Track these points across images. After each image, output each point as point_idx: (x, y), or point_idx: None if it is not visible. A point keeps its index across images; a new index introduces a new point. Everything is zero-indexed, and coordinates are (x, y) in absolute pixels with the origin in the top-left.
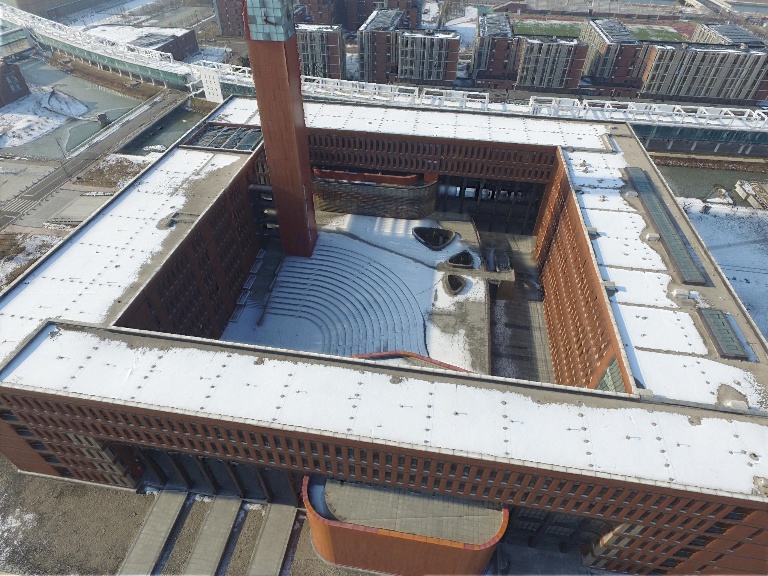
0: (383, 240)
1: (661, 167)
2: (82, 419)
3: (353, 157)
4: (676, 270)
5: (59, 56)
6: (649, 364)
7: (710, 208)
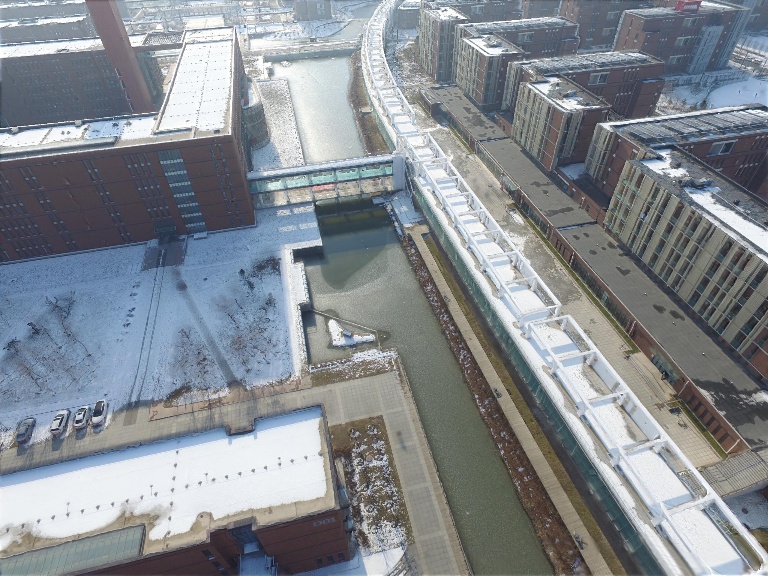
0: None
1: (412, 281)
2: None
3: None
4: None
5: None
6: None
7: (271, 300)
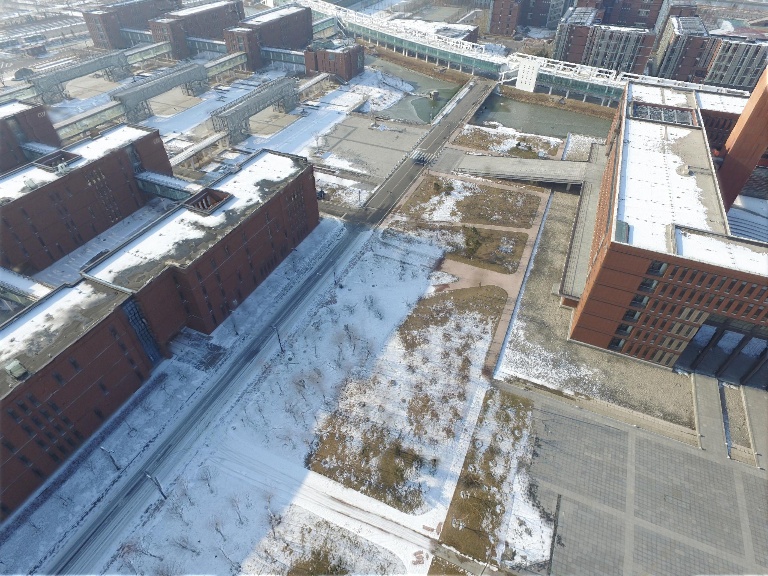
0: None
1: None
2: (728, 295)
3: None
4: None
5: (362, 42)
6: None
7: None
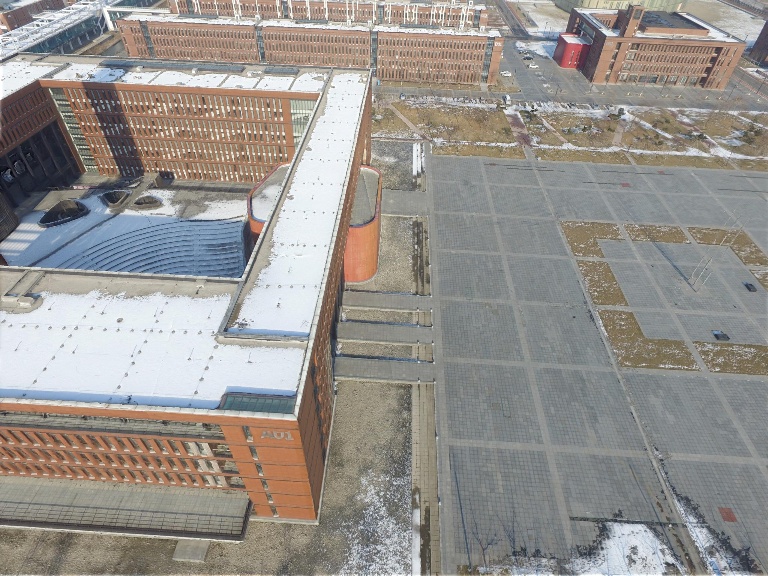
0: (45, 247)
1: None
2: None
3: None
4: (230, 71)
5: None
6: (300, 89)
7: None
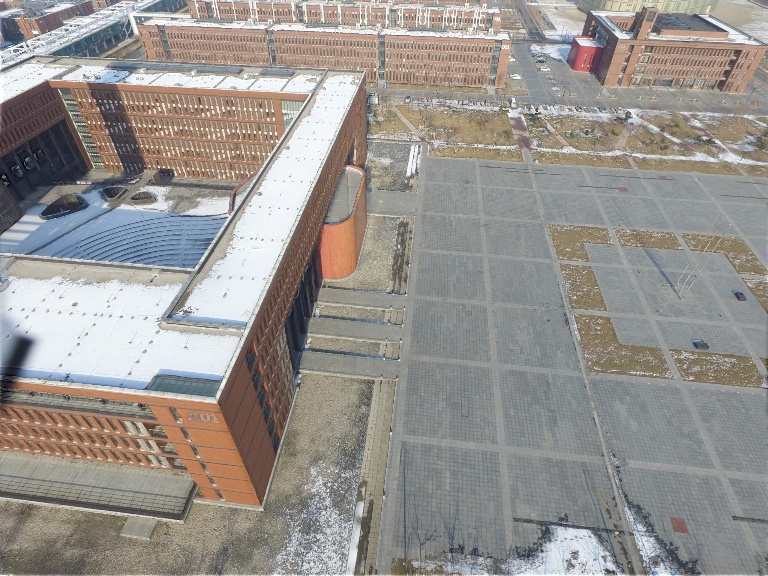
0: (43, 238)
1: None
2: None
3: None
4: (227, 73)
5: None
6: (291, 90)
7: None
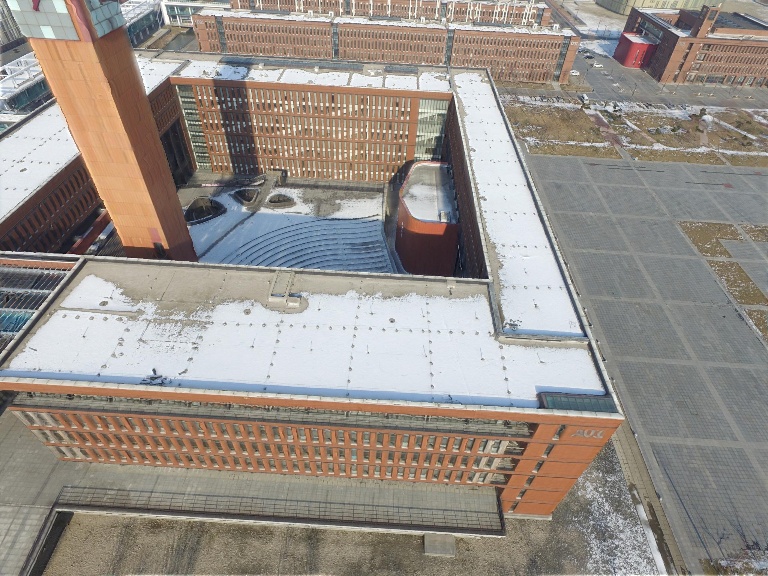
0: (197, 246)
1: None
2: None
3: (71, 214)
4: (351, 70)
5: None
6: None
7: None
